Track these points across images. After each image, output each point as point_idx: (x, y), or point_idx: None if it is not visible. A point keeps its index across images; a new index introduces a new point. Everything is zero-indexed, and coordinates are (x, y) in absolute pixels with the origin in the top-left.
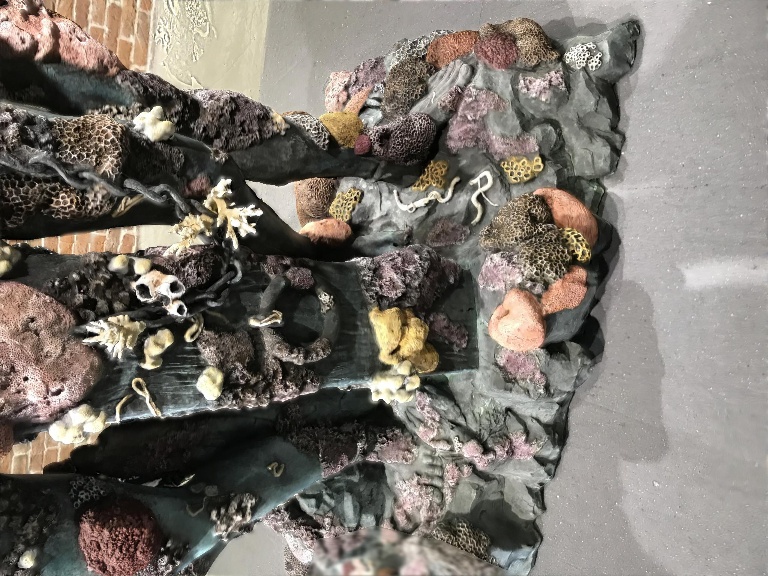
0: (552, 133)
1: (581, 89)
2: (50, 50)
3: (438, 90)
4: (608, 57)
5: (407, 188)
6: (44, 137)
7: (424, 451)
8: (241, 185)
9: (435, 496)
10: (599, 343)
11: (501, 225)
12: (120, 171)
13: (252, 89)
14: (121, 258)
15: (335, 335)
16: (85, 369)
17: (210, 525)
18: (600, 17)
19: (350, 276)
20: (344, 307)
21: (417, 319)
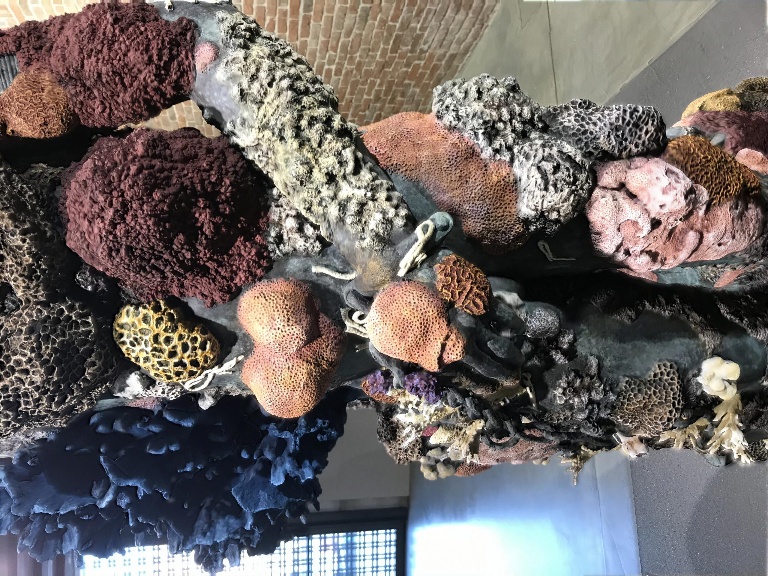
0: None
1: None
2: None
3: None
4: None
5: None
6: (605, 412)
7: None
8: None
9: None
10: None
11: None
12: None
13: None
14: None
15: None
16: None
17: None
18: None
19: None
20: None
21: None
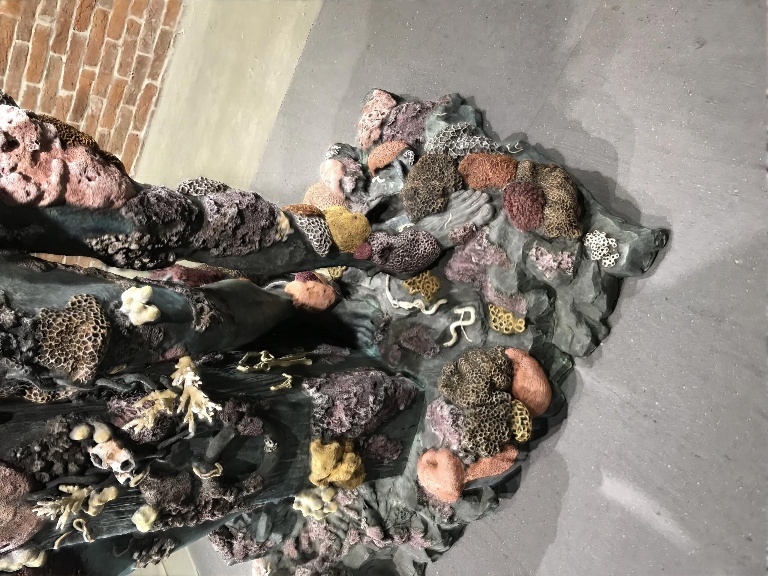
0: (545, 302)
1: (586, 279)
2: (55, 198)
3: (456, 215)
4: (624, 261)
5: (399, 279)
6: (26, 345)
7: (338, 506)
8: (217, 342)
9: (335, 544)
10: (515, 484)
11: (464, 373)
12: (93, 376)
13: (307, 4)
14: (82, 433)
15: (270, 472)
16: (31, 527)
17: (131, 562)
18: (640, 201)
19: (302, 412)
20: (288, 440)
21: (352, 455)
